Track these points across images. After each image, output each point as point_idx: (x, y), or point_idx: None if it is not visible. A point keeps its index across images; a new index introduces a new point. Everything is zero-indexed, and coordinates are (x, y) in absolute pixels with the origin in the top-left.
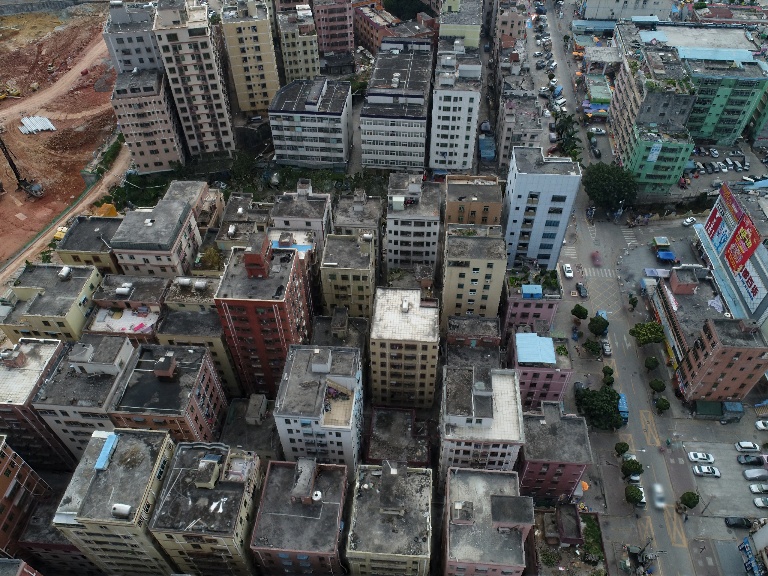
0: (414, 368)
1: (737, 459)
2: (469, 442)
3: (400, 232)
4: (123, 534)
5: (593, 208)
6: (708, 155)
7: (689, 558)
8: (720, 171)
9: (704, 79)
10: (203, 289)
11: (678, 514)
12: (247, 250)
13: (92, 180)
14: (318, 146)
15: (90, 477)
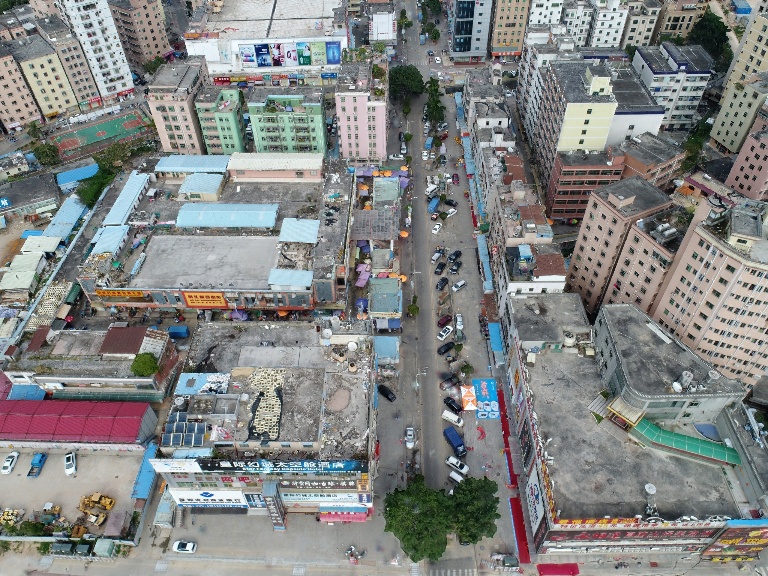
0: None
1: None
2: None
3: None
4: None
5: None
6: None
7: None
8: None
9: None
10: None
11: (405, 1)
12: None
13: None
14: None
15: None
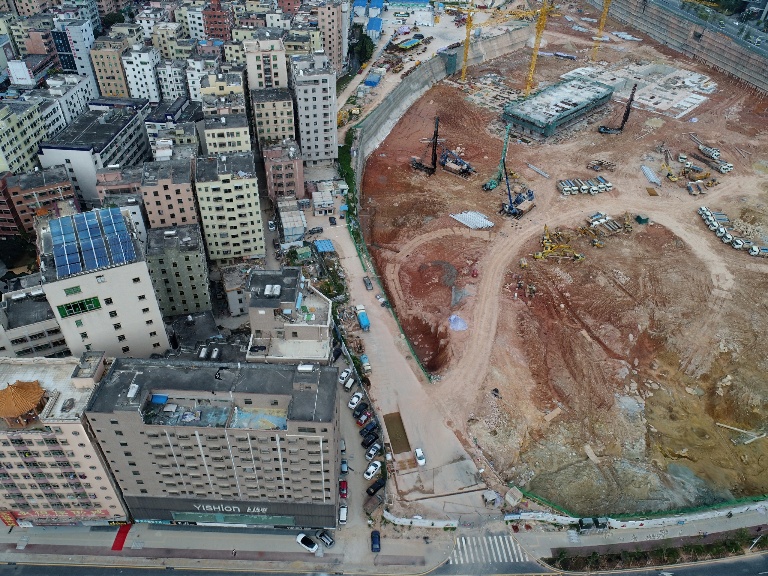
0: None
1: None
2: None
3: None
4: None
5: None
6: None
7: None
8: None
9: None
10: None
11: None
12: None
13: None
14: None
15: None
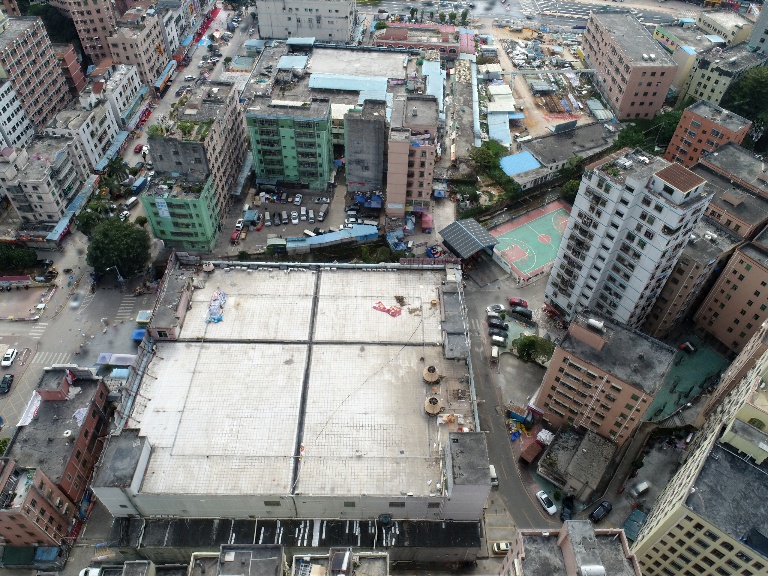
0: None
1: None
2: None
3: None
4: None
5: (92, 274)
6: (291, 202)
7: None
8: (290, 222)
9: (258, 119)
10: None
11: None
12: None
13: None
14: None
15: None
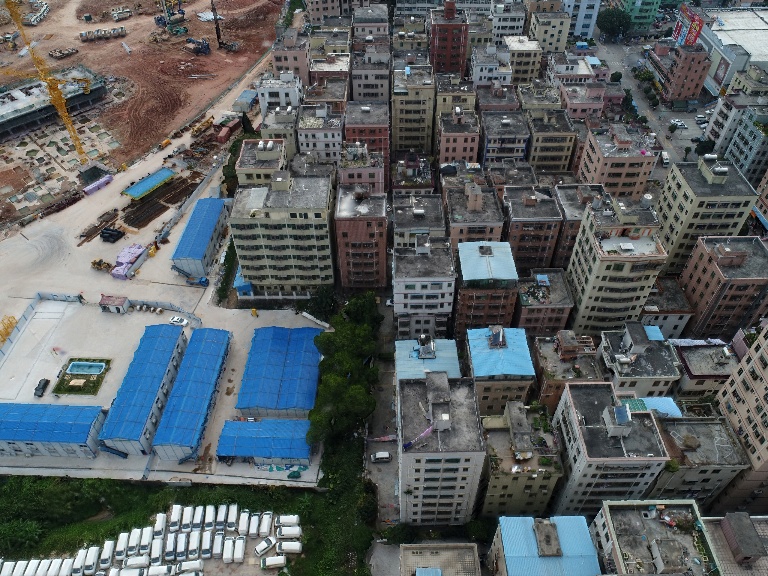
0: (527, 73)
1: (696, 123)
2: (568, 79)
3: (501, 27)
4: (424, 99)
5: (604, 35)
6: (672, 13)
7: (674, 150)
8: None
9: None
10: (413, 36)
11: (667, 139)
12: (447, 1)
13: (282, 31)
14: (426, 7)
15: (403, 80)
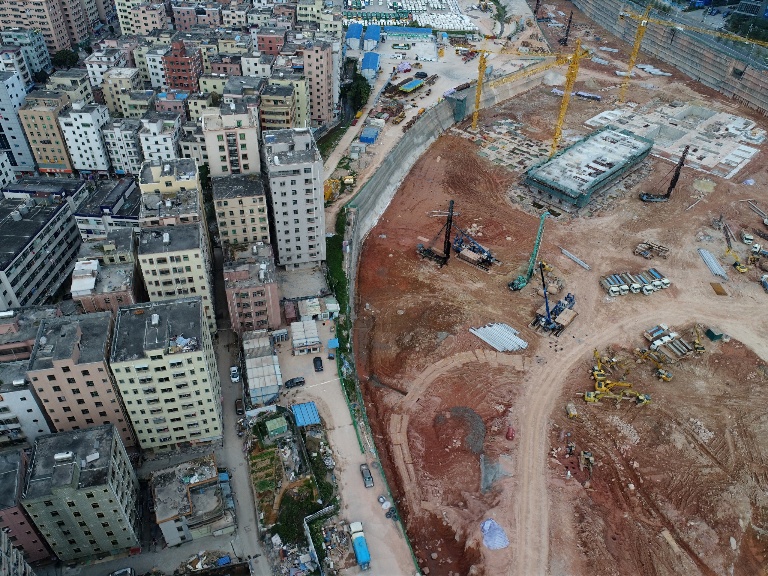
0: None
1: None
2: None
3: None
4: None
5: None
6: None
7: None
8: None
9: None
10: None
11: None
12: None
13: None
14: None
15: None
